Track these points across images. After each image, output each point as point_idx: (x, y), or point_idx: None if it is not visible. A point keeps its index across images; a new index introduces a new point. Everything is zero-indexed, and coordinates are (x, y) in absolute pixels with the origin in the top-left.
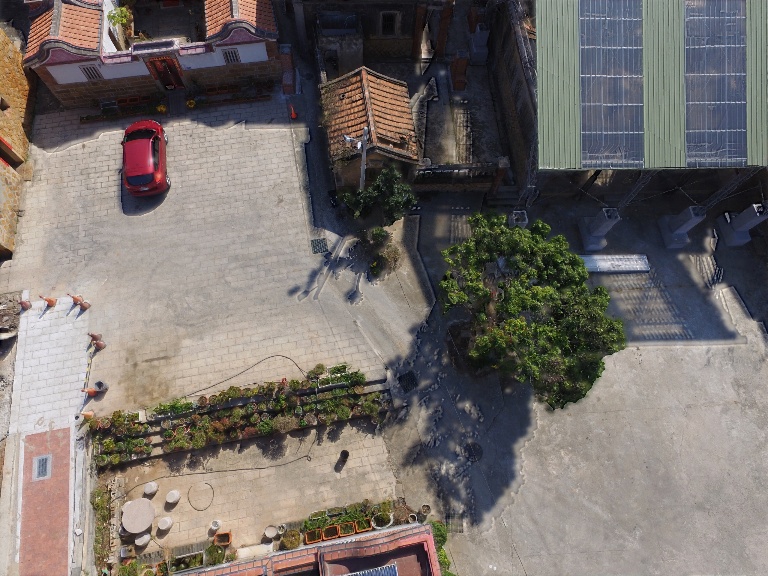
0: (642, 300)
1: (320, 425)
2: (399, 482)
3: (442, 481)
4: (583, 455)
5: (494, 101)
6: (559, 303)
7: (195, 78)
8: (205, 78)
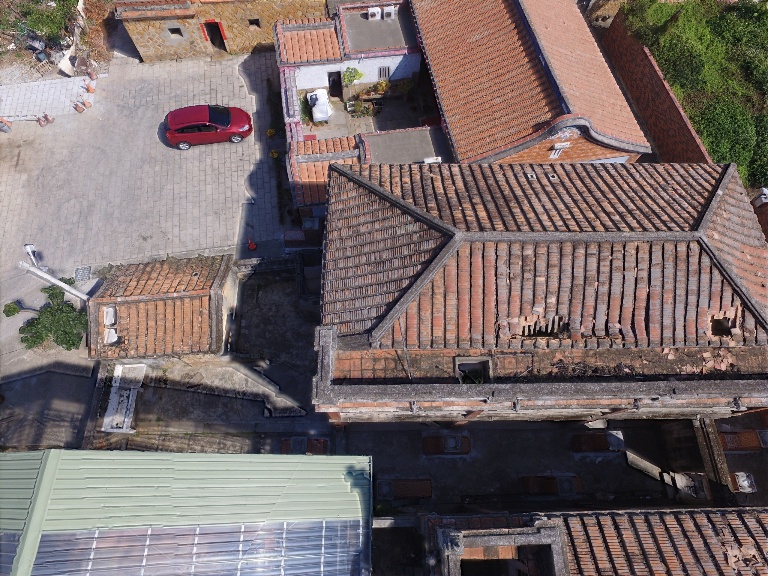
0: None
1: None
2: None
3: None
4: None
5: None
6: None
7: None
8: None
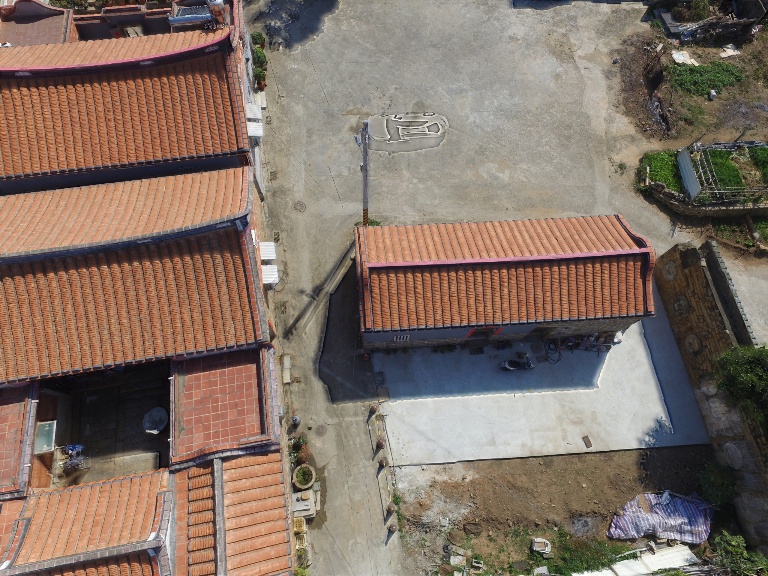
0: None
1: None
2: None
3: (270, 28)
4: (365, 22)
5: None
6: None
7: None
8: None
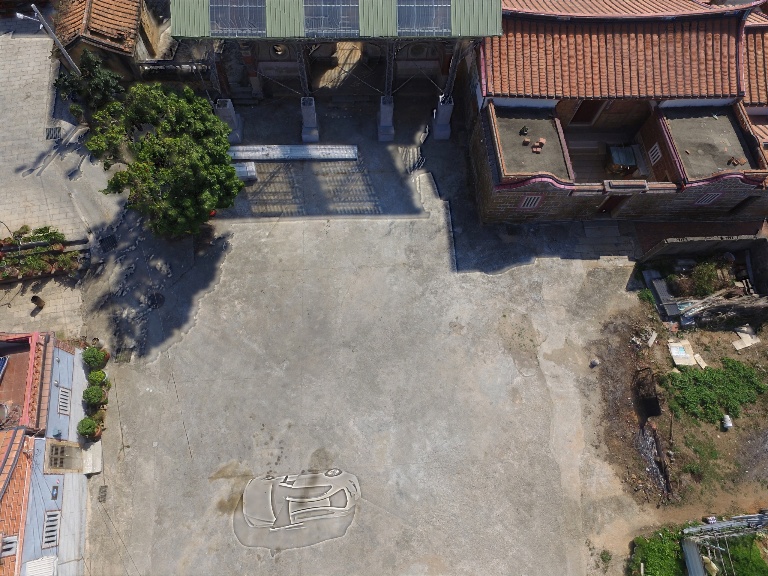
0: (344, 182)
1: (26, 280)
2: (85, 324)
3: (121, 323)
4: (254, 304)
5: None
6: (177, 148)
7: None
8: None
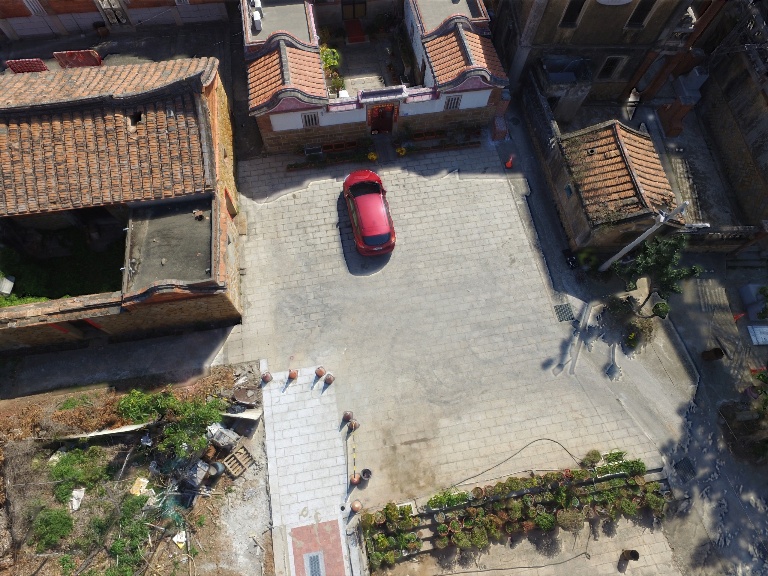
0: None
1: (593, 517)
2: None
3: None
4: None
5: (710, 149)
6: None
7: (406, 124)
8: (416, 124)
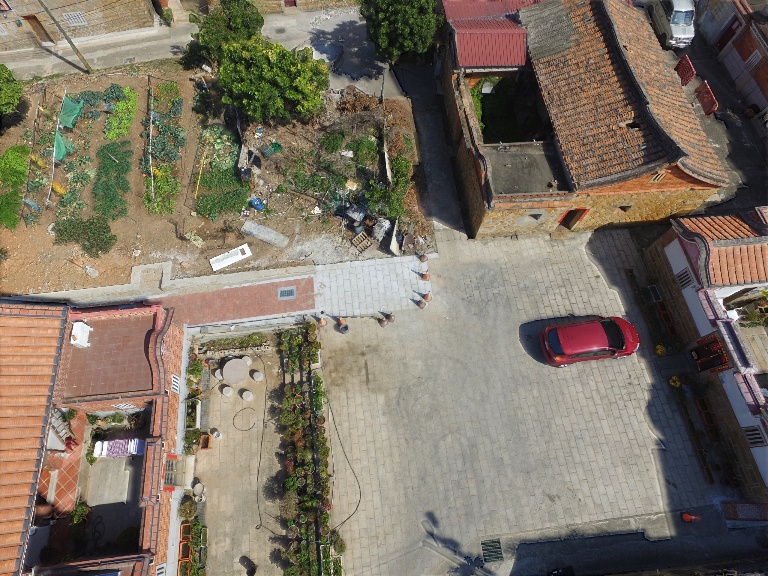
0: None
1: (289, 541)
2: None
3: None
4: None
5: None
6: None
7: (712, 386)
8: (716, 398)
